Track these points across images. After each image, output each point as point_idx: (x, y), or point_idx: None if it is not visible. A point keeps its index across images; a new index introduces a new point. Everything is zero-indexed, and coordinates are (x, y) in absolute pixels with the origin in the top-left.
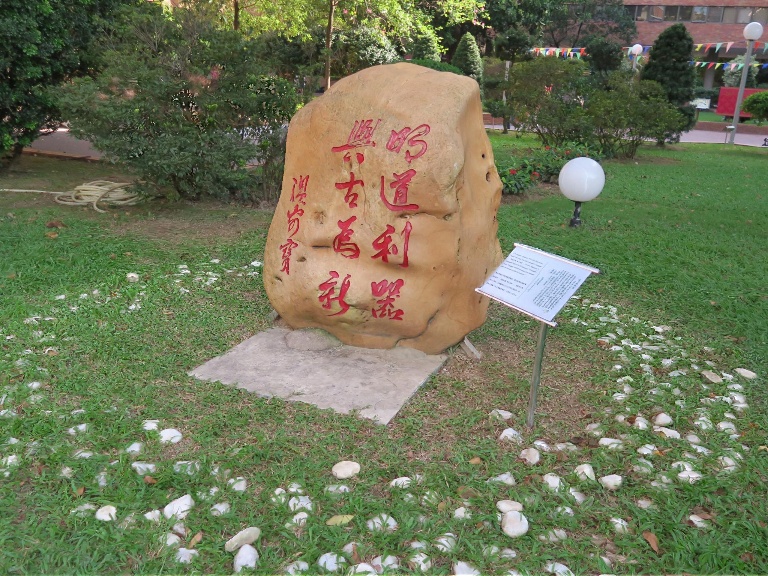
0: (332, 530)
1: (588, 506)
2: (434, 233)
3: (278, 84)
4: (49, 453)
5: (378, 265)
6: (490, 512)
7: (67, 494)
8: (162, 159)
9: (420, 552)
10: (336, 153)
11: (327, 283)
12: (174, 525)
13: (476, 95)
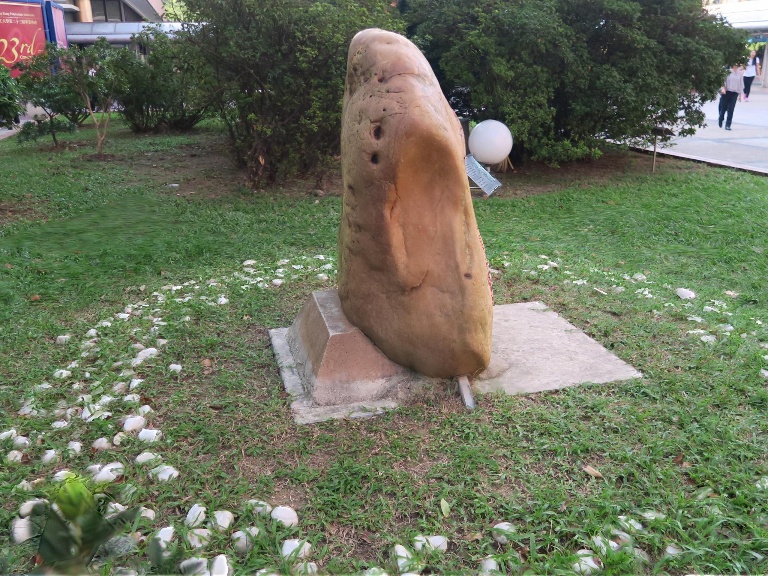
0: None
1: None
2: None
3: None
4: None
5: None
6: None
7: None
8: None
9: None
10: None
11: None
12: None
13: None
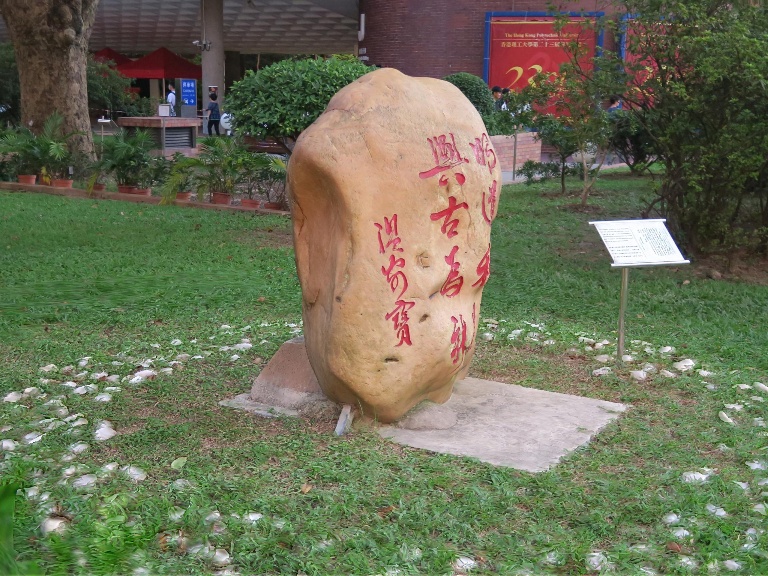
0: None
1: None
2: None
3: None
4: None
5: None
6: (751, 393)
7: None
8: None
9: None
10: (429, 179)
11: None
12: None
13: None
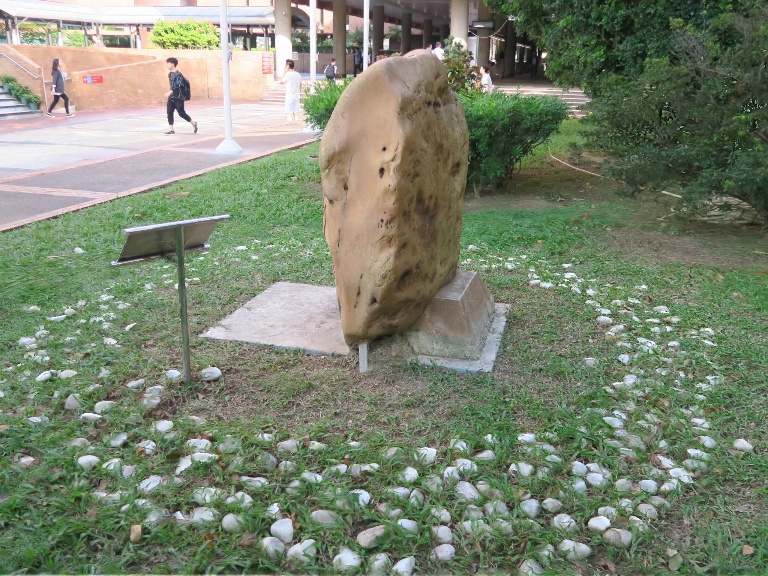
0: None
1: None
2: None
3: None
4: None
5: None
6: None
7: None
8: None
9: None
10: None
11: None
12: None
13: (376, 80)
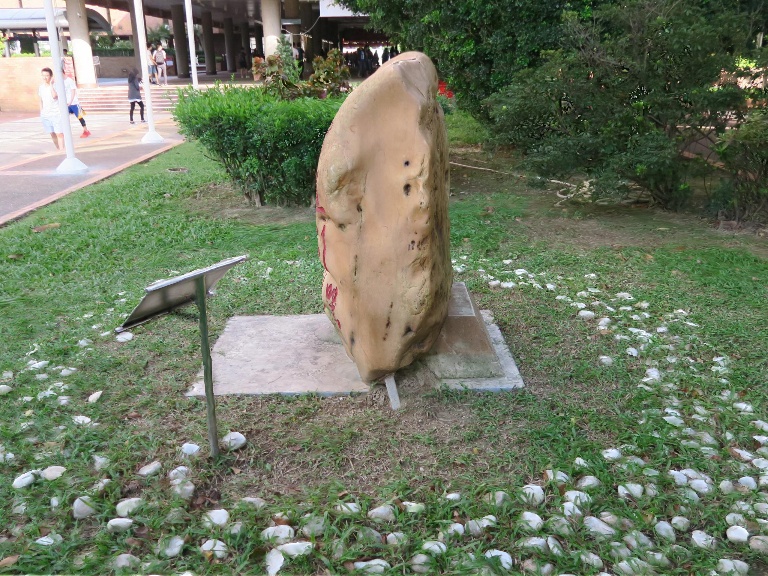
0: (13, 412)
1: None
2: (336, 243)
3: (763, 76)
4: None
5: None
6: None
7: None
8: None
9: None
10: None
11: None
12: None
13: (392, 87)
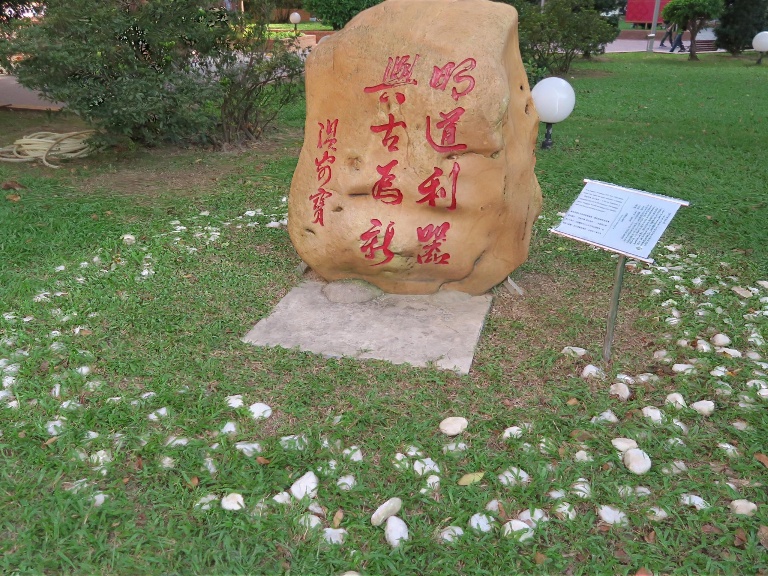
0: (470, 490)
1: (695, 435)
2: (482, 172)
3: (231, 15)
4: (139, 444)
5: (423, 210)
6: (609, 452)
7: (182, 486)
8: (128, 106)
9: (563, 501)
10: (370, 94)
11: (369, 232)
12: (309, 505)
13: (515, 23)
